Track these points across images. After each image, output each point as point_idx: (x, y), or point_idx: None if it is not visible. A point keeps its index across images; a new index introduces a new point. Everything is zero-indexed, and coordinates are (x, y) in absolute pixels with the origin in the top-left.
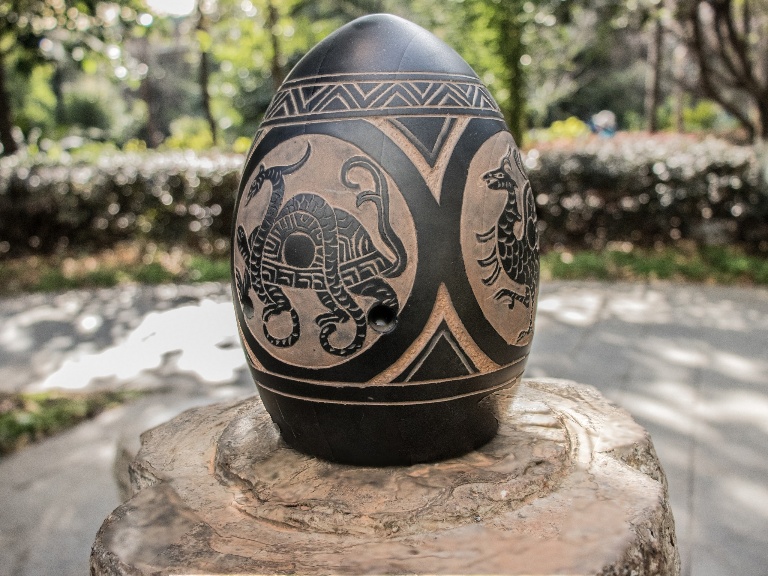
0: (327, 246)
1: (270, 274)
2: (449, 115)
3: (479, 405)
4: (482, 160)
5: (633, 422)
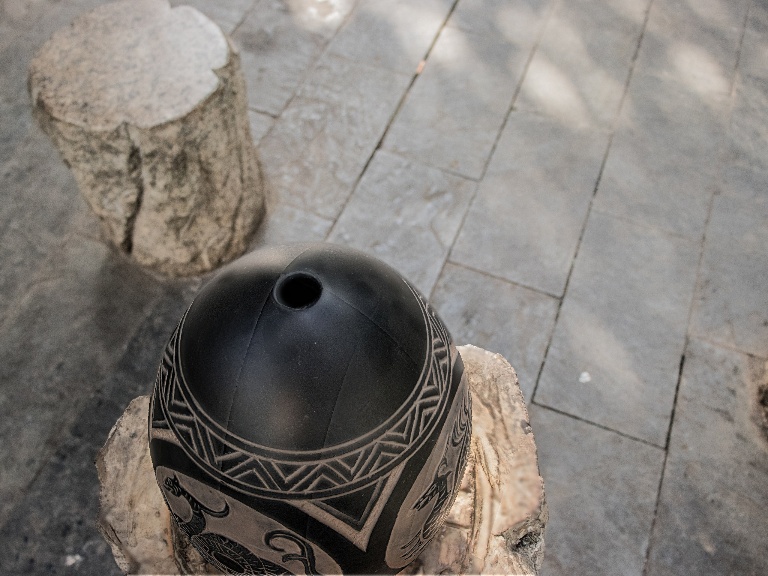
0: (256, 573)
1: (202, 552)
2: (381, 476)
3: None
4: (414, 494)
5: (535, 470)
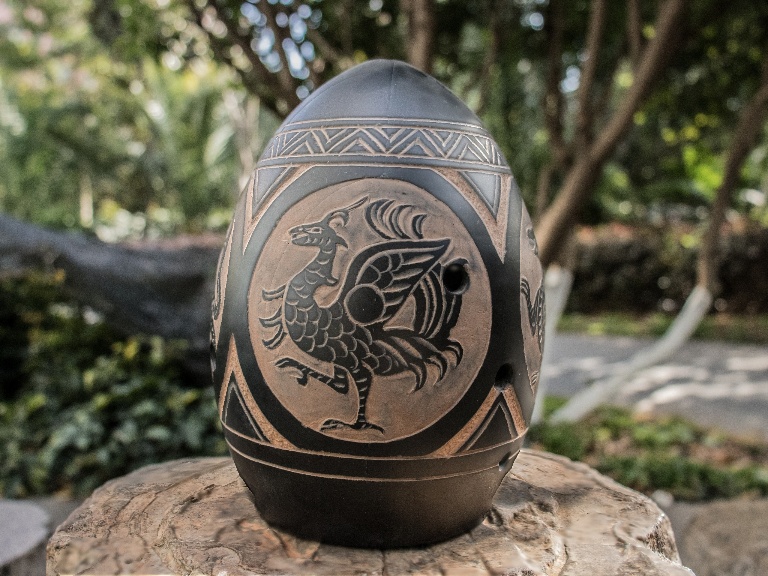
0: None
1: None
2: (292, 164)
3: (481, 532)
4: (299, 212)
5: None
